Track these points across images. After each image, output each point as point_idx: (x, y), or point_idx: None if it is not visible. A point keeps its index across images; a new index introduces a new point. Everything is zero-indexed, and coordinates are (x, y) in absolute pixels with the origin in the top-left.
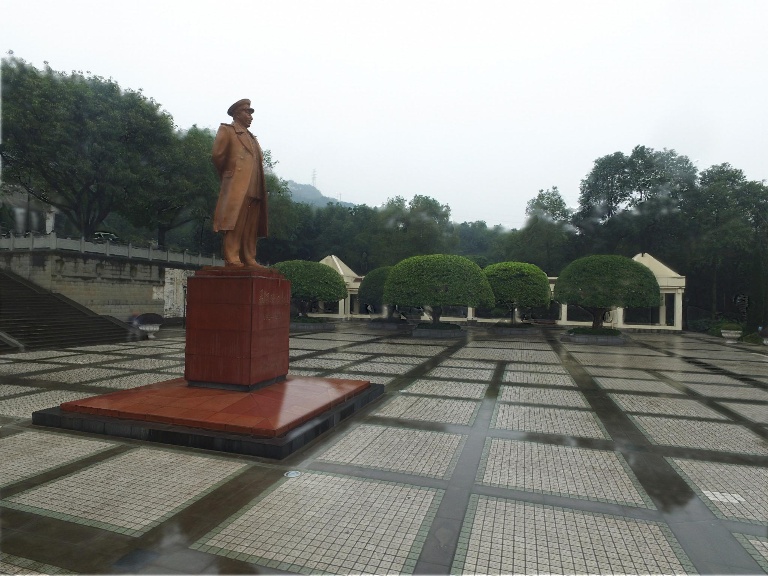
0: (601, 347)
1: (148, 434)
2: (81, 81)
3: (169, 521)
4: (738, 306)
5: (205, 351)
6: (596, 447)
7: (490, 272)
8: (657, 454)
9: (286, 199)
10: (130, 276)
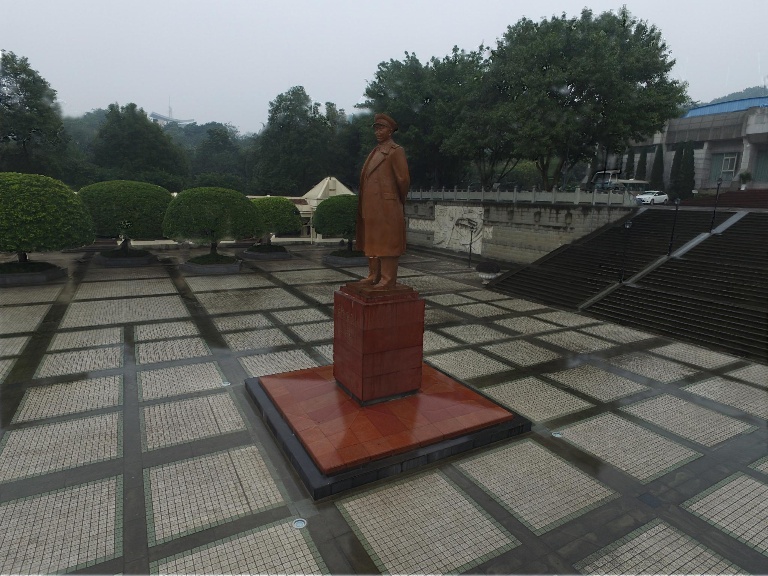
0: None
1: None
2: None
3: None
4: None
5: None
6: (3, 486)
7: None
8: None
9: None
10: None
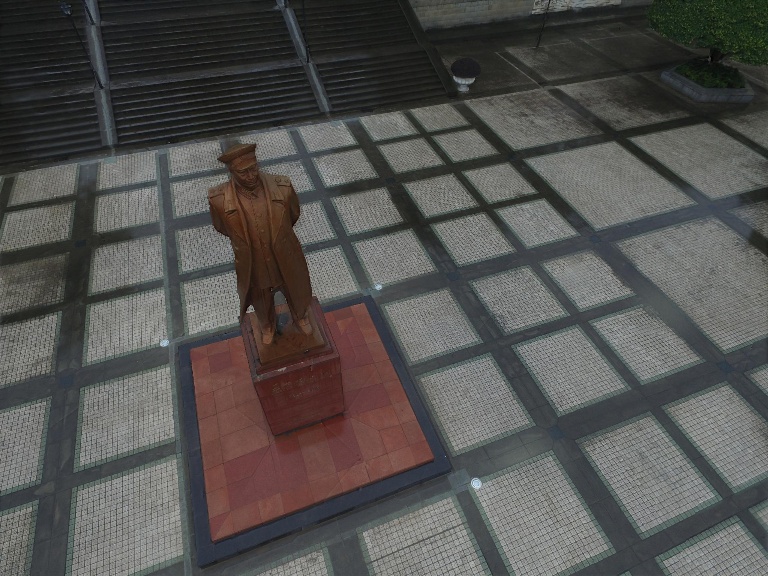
0: None
1: None
2: None
3: None
4: None
5: None
6: None
7: None
8: None
9: None
10: None
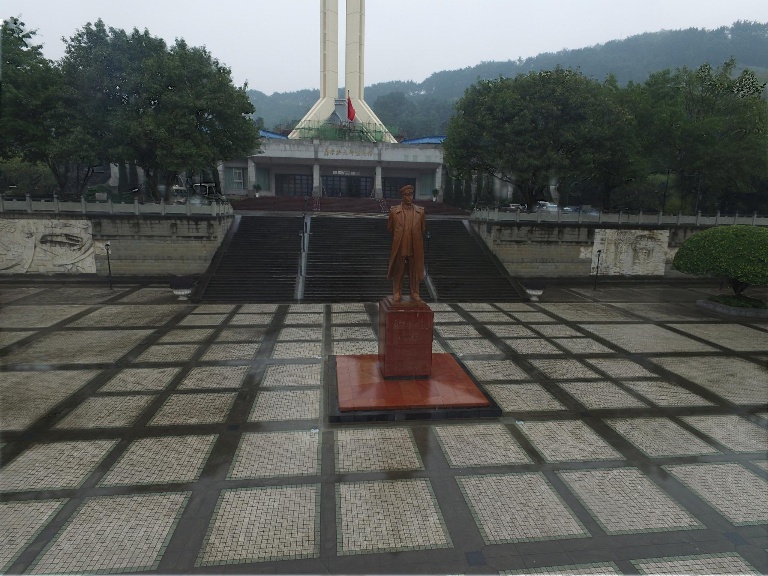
0: None
1: None
2: (514, 86)
3: (259, 422)
4: None
5: None
6: (454, 533)
7: None
8: (467, 570)
9: (754, 140)
10: (558, 238)
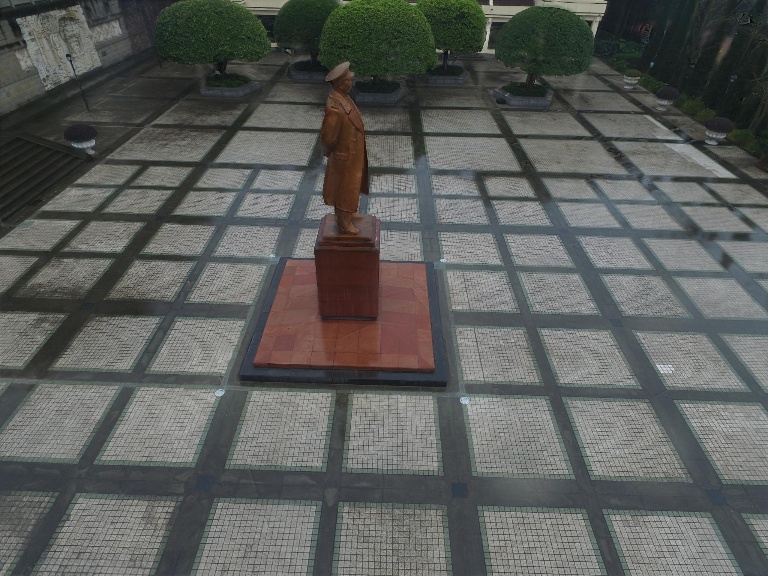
0: (535, 118)
1: (347, 381)
2: None
3: (445, 460)
4: (641, 36)
5: (337, 299)
6: (597, 327)
7: (428, 11)
8: (628, 328)
9: None
10: None
